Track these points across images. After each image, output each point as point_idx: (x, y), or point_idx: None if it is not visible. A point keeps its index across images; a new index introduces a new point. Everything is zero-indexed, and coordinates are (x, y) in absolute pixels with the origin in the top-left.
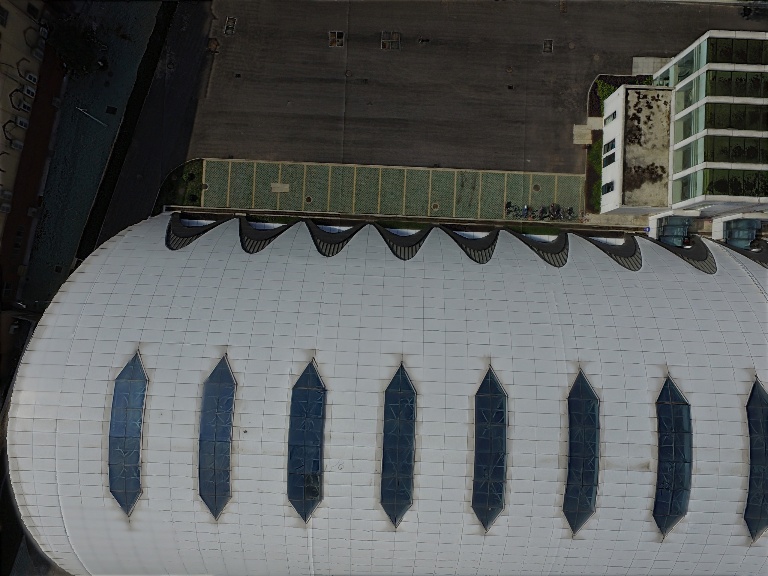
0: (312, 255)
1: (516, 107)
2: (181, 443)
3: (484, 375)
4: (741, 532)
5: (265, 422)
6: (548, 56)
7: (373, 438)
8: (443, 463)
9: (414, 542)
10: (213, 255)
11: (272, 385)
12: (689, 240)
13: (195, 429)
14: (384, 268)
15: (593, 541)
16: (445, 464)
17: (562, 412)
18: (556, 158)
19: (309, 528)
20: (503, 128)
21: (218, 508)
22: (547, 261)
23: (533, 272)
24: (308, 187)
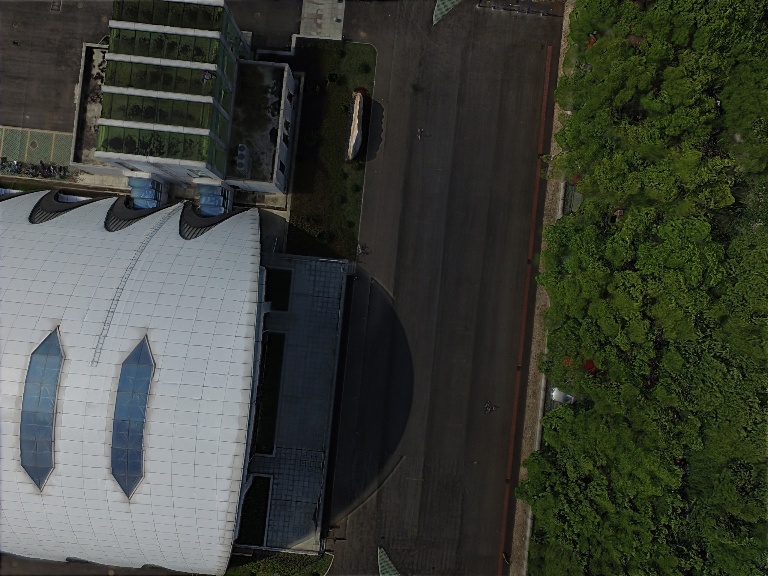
0: None
1: (19, 63)
2: None
3: None
4: (25, 479)
5: None
6: (55, 14)
7: None
8: None
9: None
10: None
11: None
12: None
13: None
14: None
15: None
16: None
17: None
18: (55, 116)
19: None
20: (4, 83)
21: None
22: None
23: None
24: None
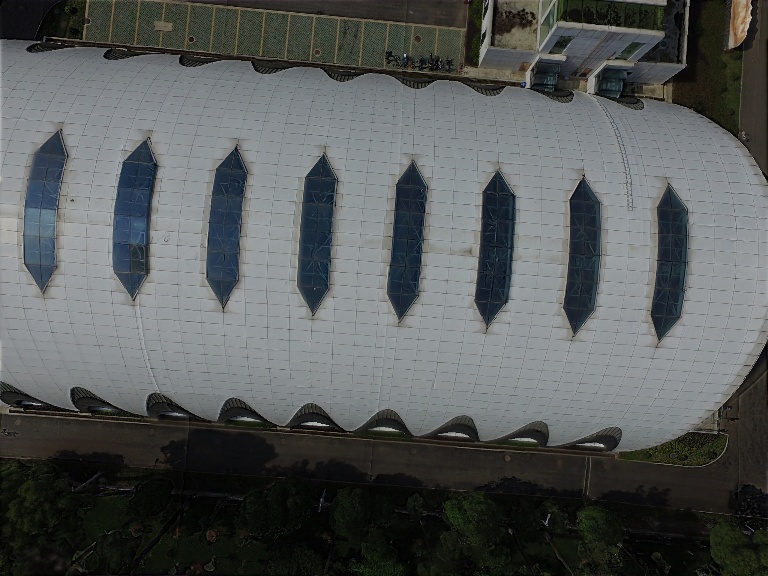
0: (172, 64)
1: None
2: (6, 209)
3: (317, 160)
4: (562, 324)
5: (93, 192)
6: None
7: (200, 212)
8: (269, 239)
9: (243, 326)
10: (71, 58)
11: (103, 159)
12: None
13: (21, 196)
14: (240, 77)
15: (419, 330)
16: (271, 240)
17: (390, 196)
18: (438, 11)
19: (137, 306)
20: None
21: (44, 279)
22: (407, 85)
23: (388, 89)
24: (191, 27)
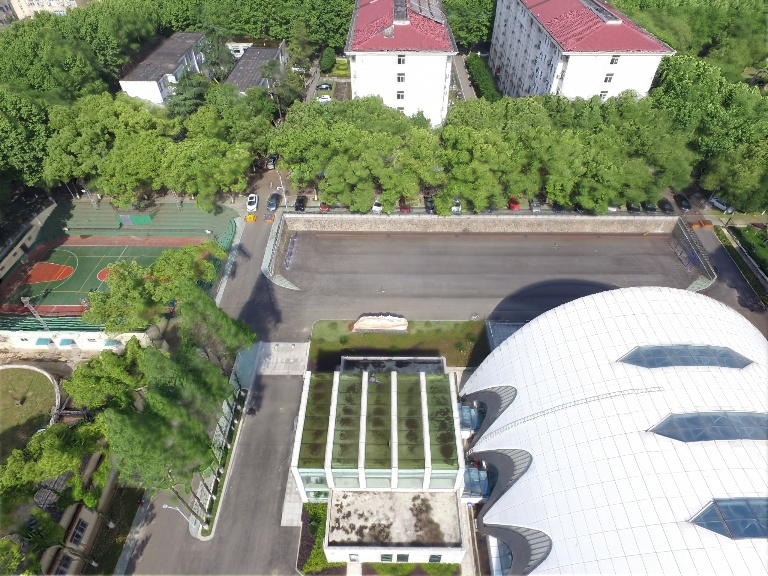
0: None
1: None
2: None
3: None
4: None
5: None
6: None
7: None
8: None
9: None
10: None
11: None
12: (475, 462)
13: None
14: None
15: None
16: None
17: None
18: None
19: None
20: None
21: None
22: None
23: None
24: None
